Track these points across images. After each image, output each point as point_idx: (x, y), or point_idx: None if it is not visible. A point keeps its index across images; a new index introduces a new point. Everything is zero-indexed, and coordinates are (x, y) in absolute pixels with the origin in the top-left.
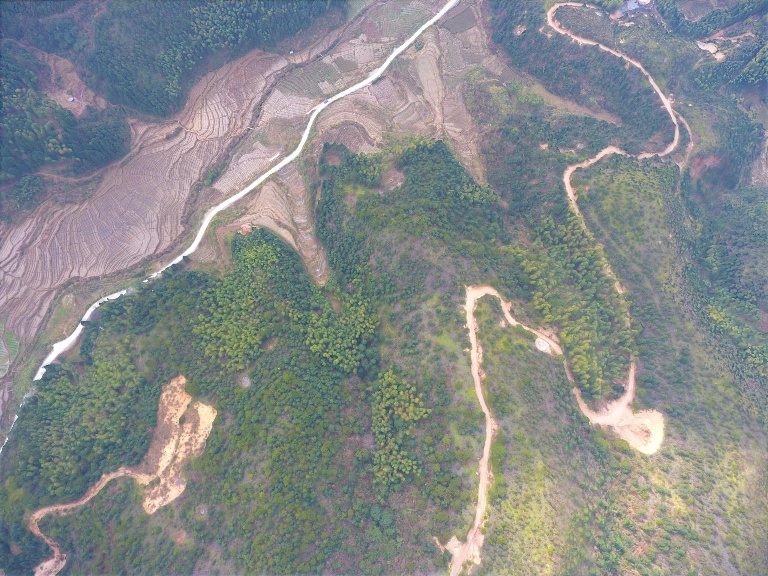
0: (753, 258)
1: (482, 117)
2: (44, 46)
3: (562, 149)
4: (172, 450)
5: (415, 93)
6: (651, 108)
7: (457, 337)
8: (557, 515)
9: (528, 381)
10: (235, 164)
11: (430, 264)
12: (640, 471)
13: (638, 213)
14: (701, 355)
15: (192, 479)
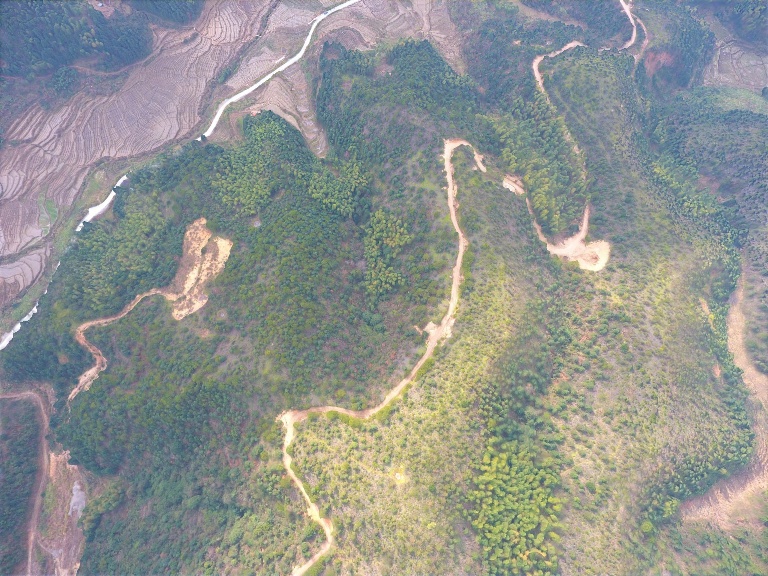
0: (695, 131)
1: (464, 24)
2: None
3: (533, 45)
4: (195, 275)
5: (405, 6)
6: (613, 13)
7: (436, 180)
8: (515, 300)
9: (494, 206)
10: (245, 65)
11: (415, 126)
12: (587, 281)
13: (594, 87)
14: (643, 196)
15: (213, 292)
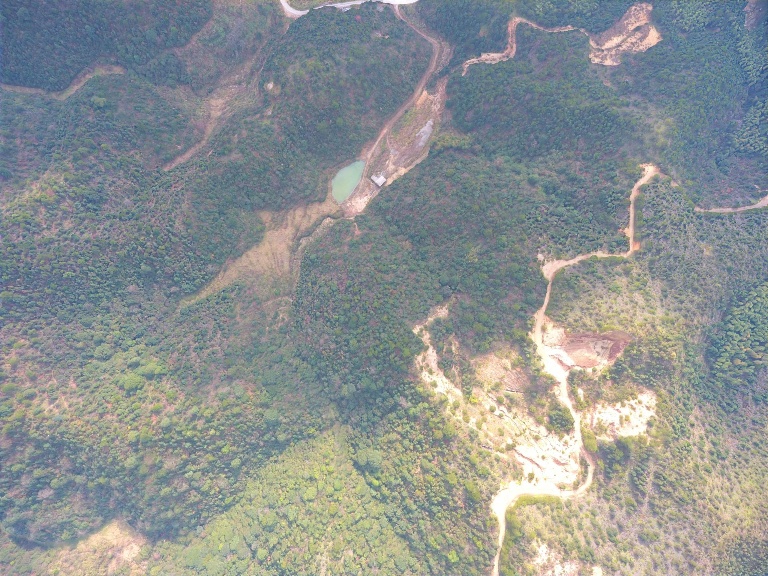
0: None
1: None
2: None
3: None
4: (618, 42)
5: None
6: None
7: None
8: None
9: None
10: None
11: None
12: None
13: None
14: None
15: (630, 61)
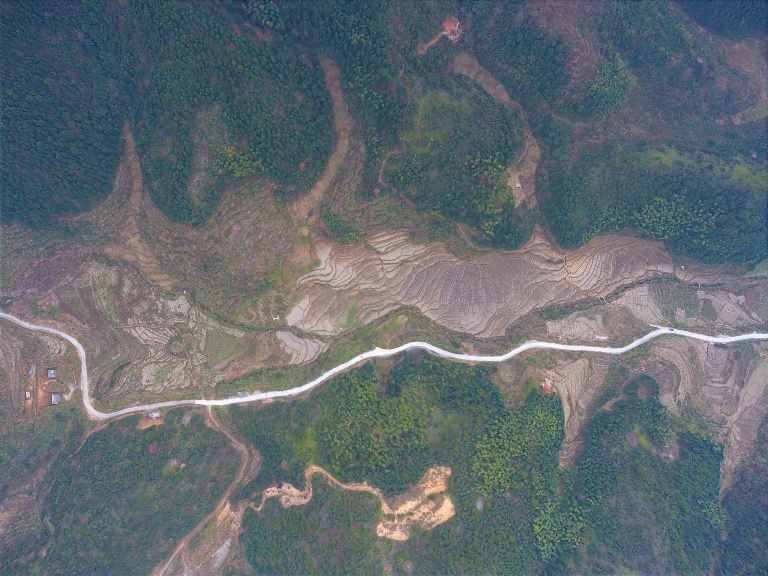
0: None
1: (765, 449)
2: (536, 130)
3: None
4: (412, 507)
5: (736, 382)
6: None
7: None
8: None
9: None
10: (573, 319)
11: (652, 553)
12: None
13: None
14: None
15: (416, 542)
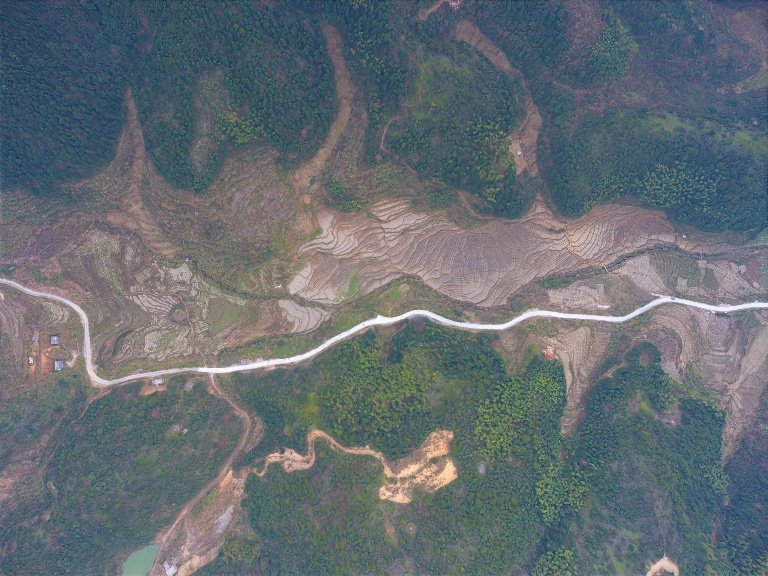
0: None
1: (767, 417)
2: (537, 98)
3: None
4: (414, 470)
5: (738, 350)
6: None
7: None
8: None
9: None
10: (575, 288)
11: (654, 515)
12: None
13: None
14: None
15: (418, 504)
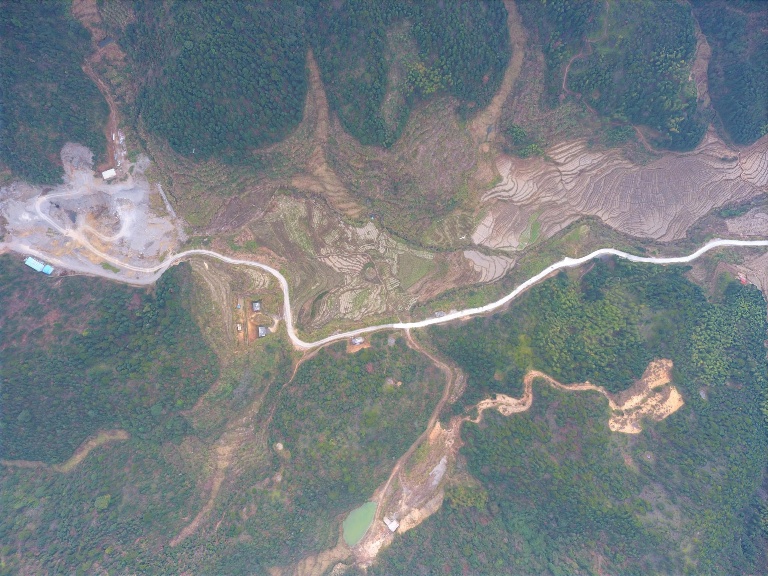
0: None
1: None
2: (707, 27)
3: None
4: (638, 401)
5: None
6: None
7: None
8: None
9: None
10: (752, 215)
11: None
12: None
13: None
14: None
15: (652, 433)
